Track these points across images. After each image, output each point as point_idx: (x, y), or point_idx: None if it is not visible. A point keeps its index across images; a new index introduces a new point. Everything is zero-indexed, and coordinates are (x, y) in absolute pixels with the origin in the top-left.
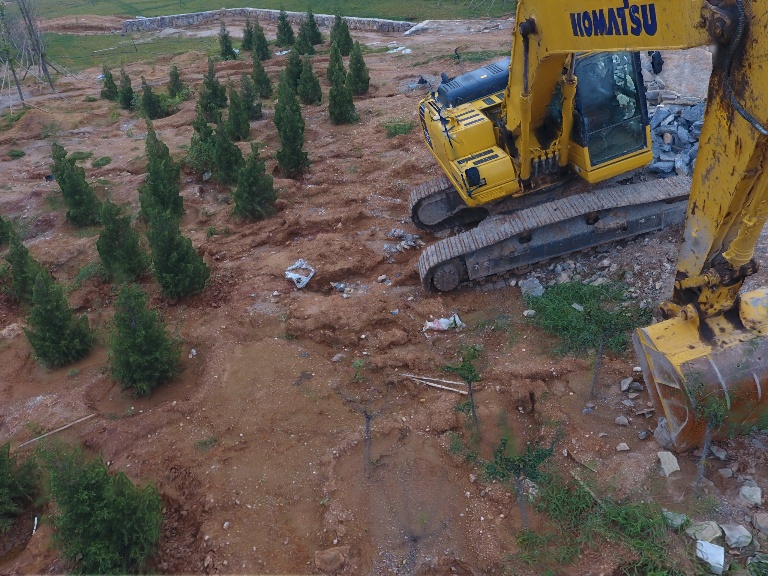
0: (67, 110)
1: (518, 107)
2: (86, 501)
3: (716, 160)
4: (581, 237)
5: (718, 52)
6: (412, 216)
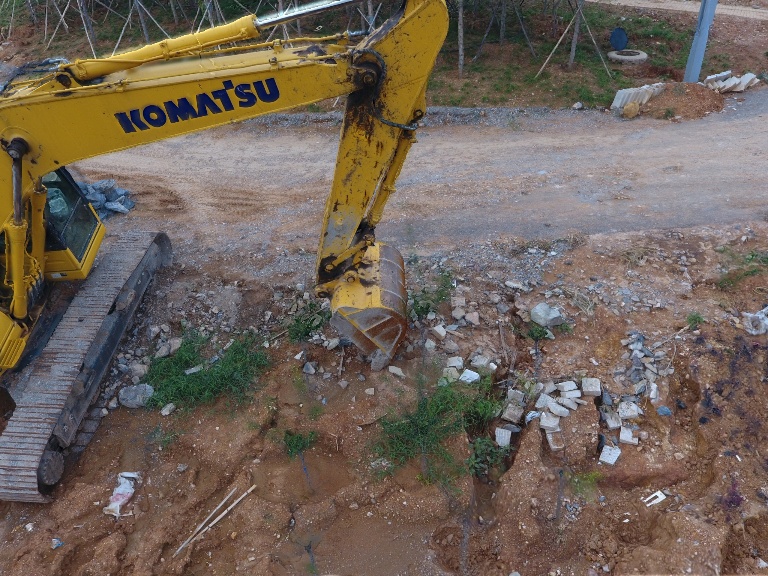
0: None
1: None
2: None
3: (358, 164)
4: (116, 328)
5: (354, 95)
6: None
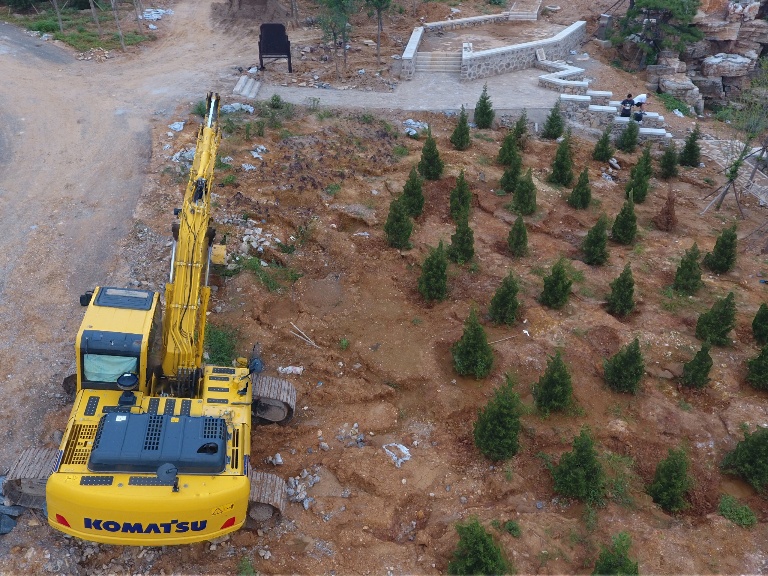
0: None
1: None
2: None
3: None
4: None
5: None
6: None
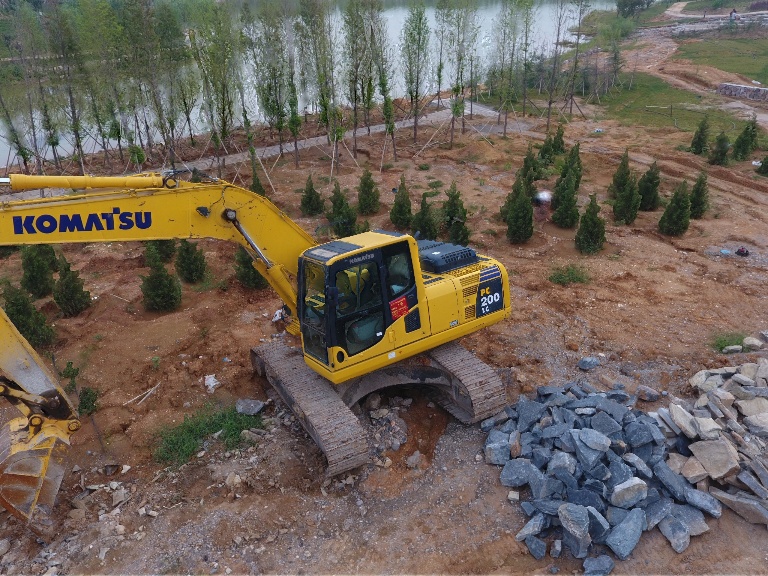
0: (511, 149)
1: None
2: (7, 306)
3: None
4: None
5: None
6: None
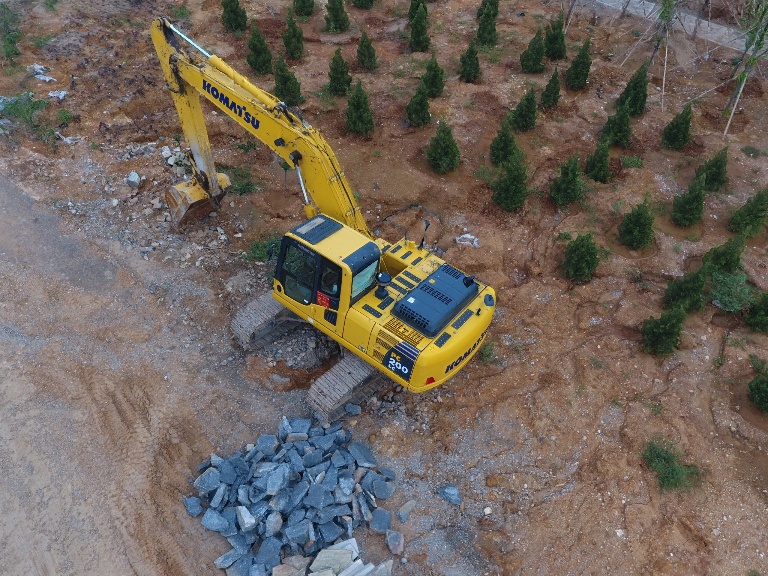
0: None
1: None
2: None
3: None
4: None
5: None
6: None
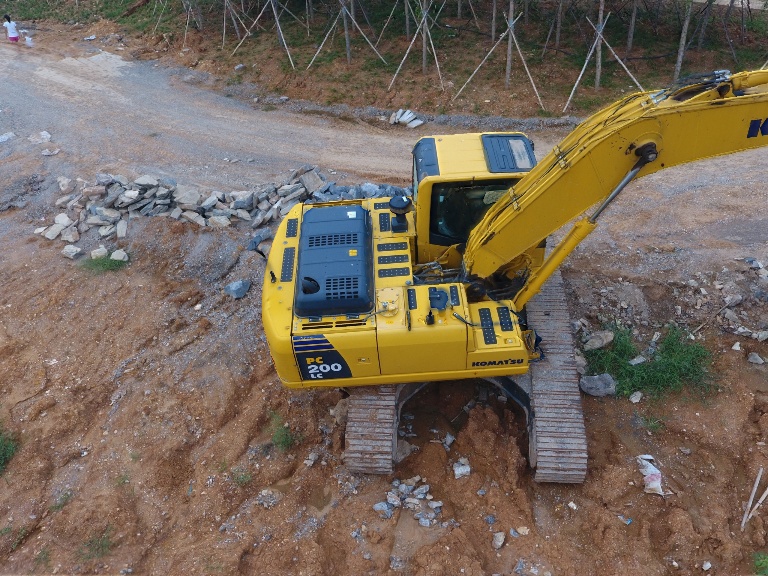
0: None
1: (512, 247)
2: None
3: None
4: None
5: None
6: (391, 466)
